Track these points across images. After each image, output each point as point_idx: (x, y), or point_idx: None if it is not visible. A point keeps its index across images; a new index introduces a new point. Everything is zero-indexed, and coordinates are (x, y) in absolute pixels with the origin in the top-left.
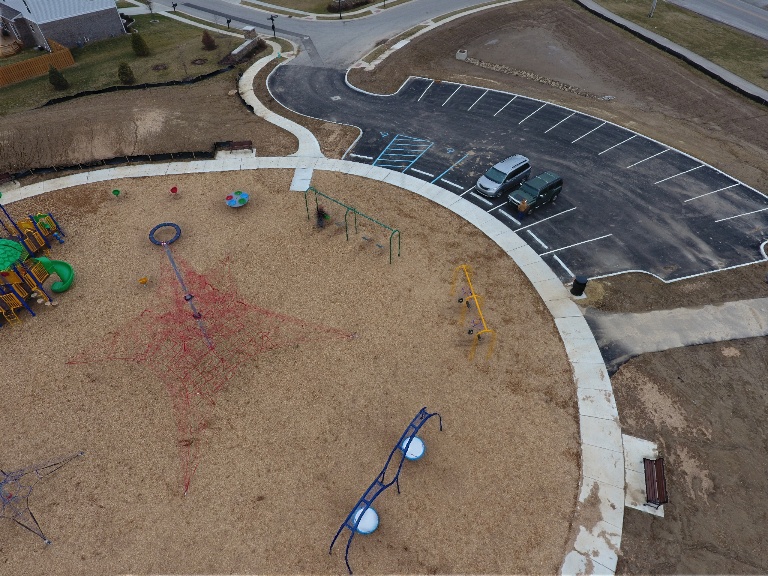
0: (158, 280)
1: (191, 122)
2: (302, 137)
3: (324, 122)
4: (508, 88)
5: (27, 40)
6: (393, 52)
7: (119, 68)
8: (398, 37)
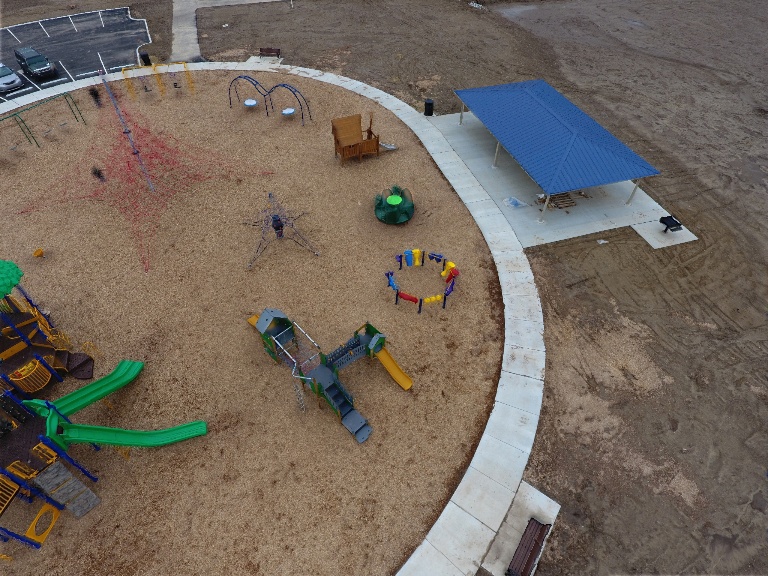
0: None
1: None
2: None
3: None
4: None
5: None
6: None
7: None
8: None
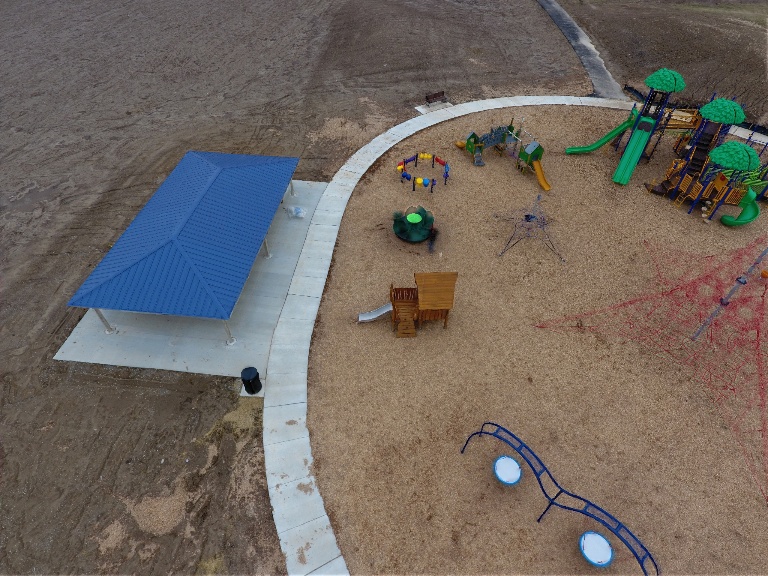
0: None
1: None
2: None
3: None
4: None
5: None
6: None
7: None
8: None
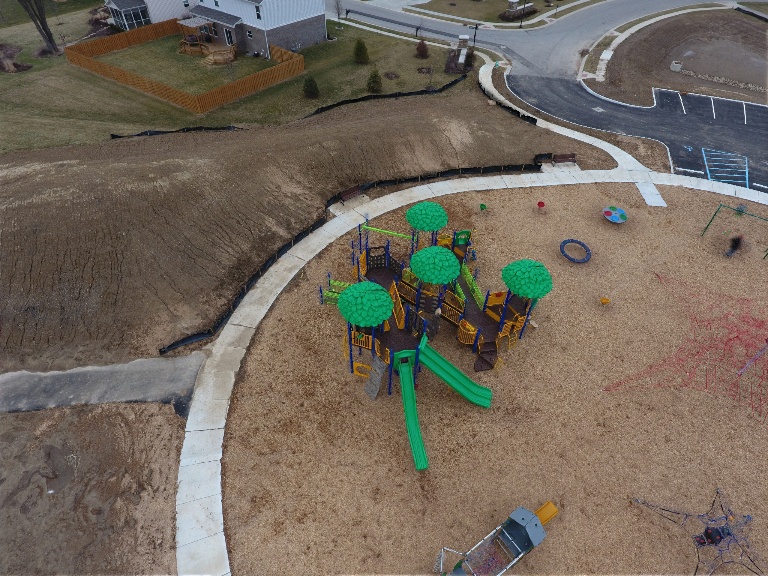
0: (610, 300)
1: (494, 133)
2: (609, 150)
3: (616, 134)
4: (764, 101)
5: (240, 46)
6: (608, 63)
7: (372, 76)
8: (597, 47)
